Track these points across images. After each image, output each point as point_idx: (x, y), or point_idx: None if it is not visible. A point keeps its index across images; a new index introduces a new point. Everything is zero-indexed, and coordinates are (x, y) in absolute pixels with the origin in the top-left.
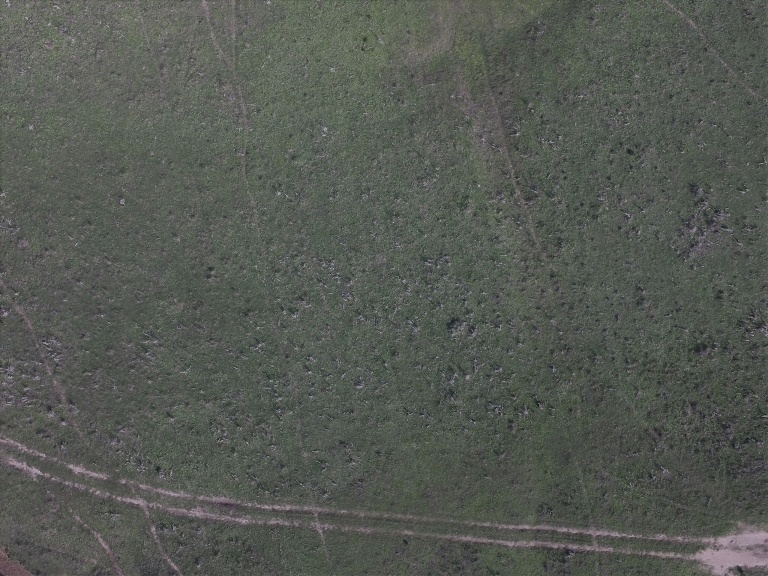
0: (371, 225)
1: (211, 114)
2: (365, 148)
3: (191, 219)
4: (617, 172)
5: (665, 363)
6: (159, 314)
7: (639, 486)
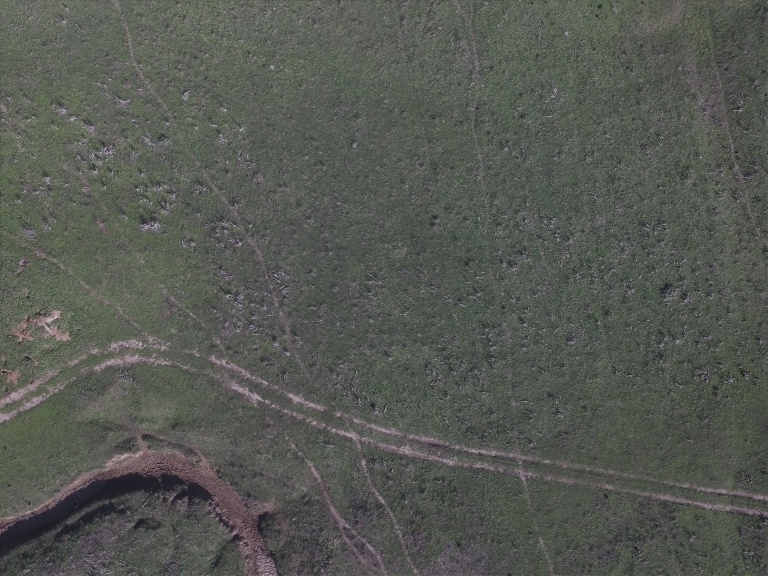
0: (593, 187)
1: (445, 67)
2: (591, 112)
3: (420, 167)
4: None
5: None
6: (383, 256)
7: None
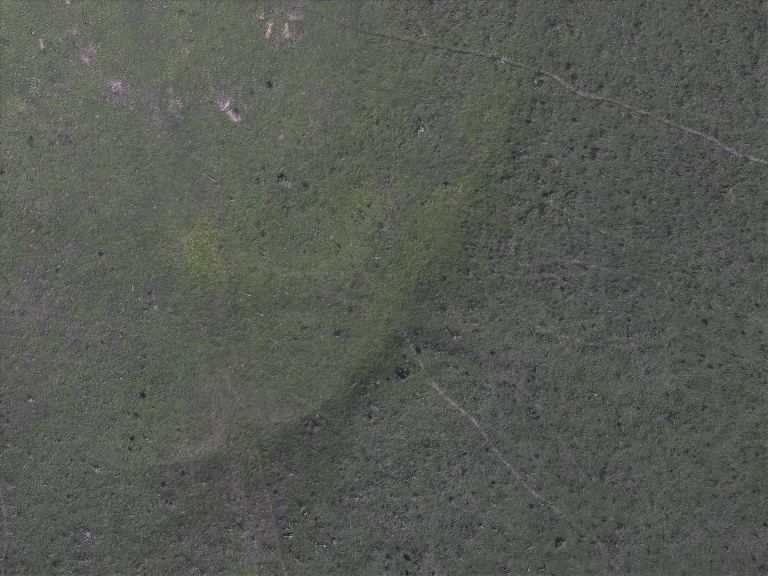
0: None
1: None
2: (130, 552)
3: None
4: None
5: None
6: None
7: None
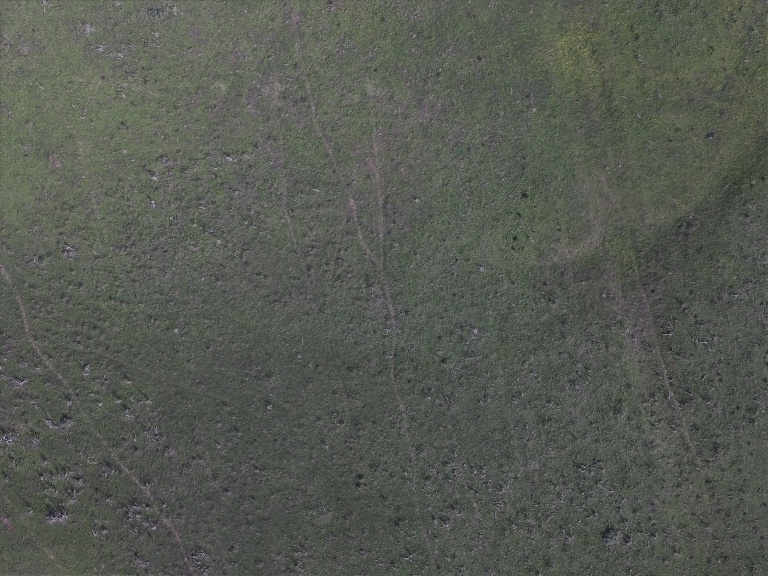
0: (523, 430)
1: (358, 315)
2: (515, 349)
3: (339, 425)
4: None
5: None
6: (308, 523)
7: None
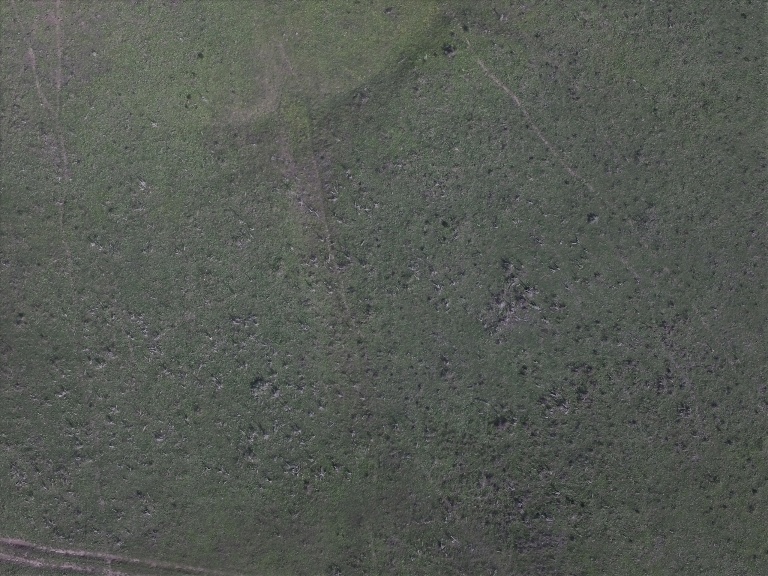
0: (183, 281)
1: (32, 162)
2: (182, 204)
3: (5, 265)
4: (431, 243)
5: (464, 434)
6: None
7: (427, 554)
